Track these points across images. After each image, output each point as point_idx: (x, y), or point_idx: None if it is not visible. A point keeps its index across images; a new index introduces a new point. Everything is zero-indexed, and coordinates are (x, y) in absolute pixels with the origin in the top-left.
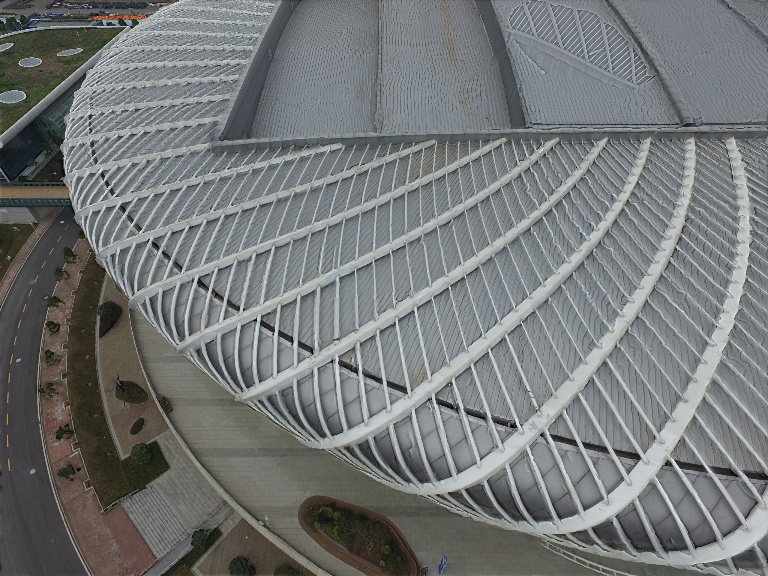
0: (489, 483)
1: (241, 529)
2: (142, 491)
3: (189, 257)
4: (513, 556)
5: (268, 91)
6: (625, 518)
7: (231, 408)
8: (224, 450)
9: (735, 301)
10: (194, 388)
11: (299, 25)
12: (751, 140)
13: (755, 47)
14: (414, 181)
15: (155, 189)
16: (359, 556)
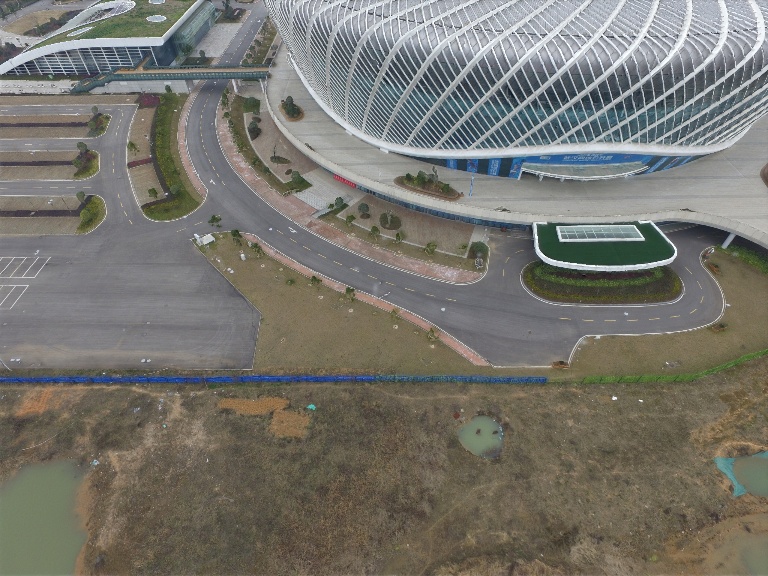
0: (494, 49)
1: (359, 204)
2: (300, 192)
3: (361, 5)
4: (507, 191)
5: None
6: (542, 53)
7: (347, 150)
8: (348, 163)
9: None
10: (324, 144)
11: None
12: None
13: None
14: None
15: None
16: (428, 190)
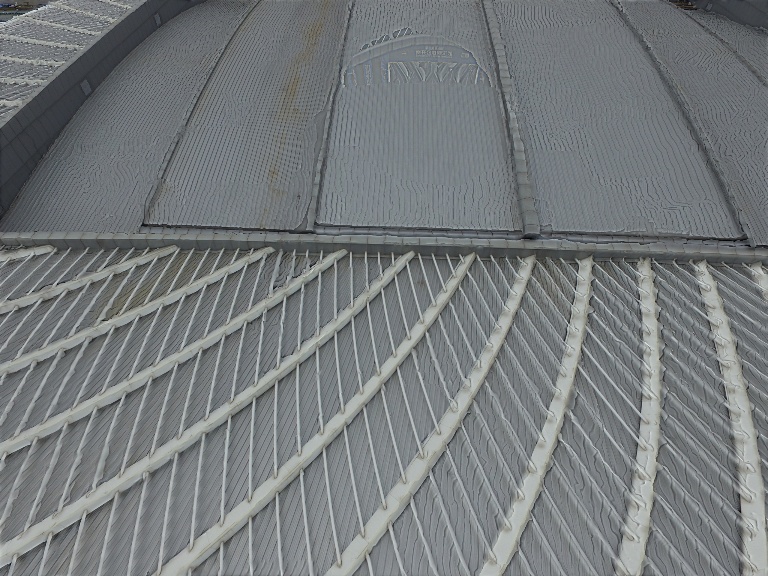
0: None
1: None
2: None
3: None
4: None
5: (65, 138)
6: None
7: None
8: None
9: None
10: None
11: (155, 45)
12: (618, 261)
13: (665, 108)
14: (112, 317)
15: None
16: None
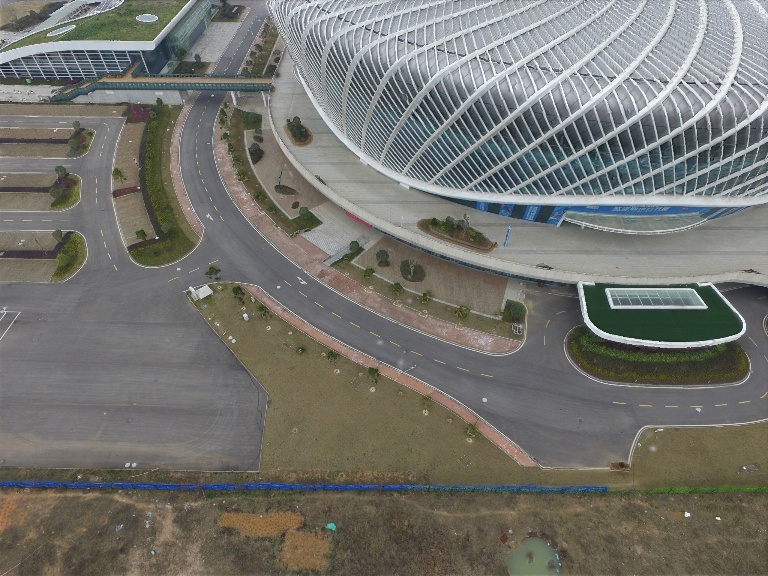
0: (551, 92)
1: (376, 248)
2: (309, 231)
3: None
4: (546, 240)
5: None
6: (609, 100)
7: (363, 184)
8: (364, 201)
9: (662, 32)
10: (336, 176)
11: None
12: None
13: None
14: None
15: (358, 6)
16: (457, 239)
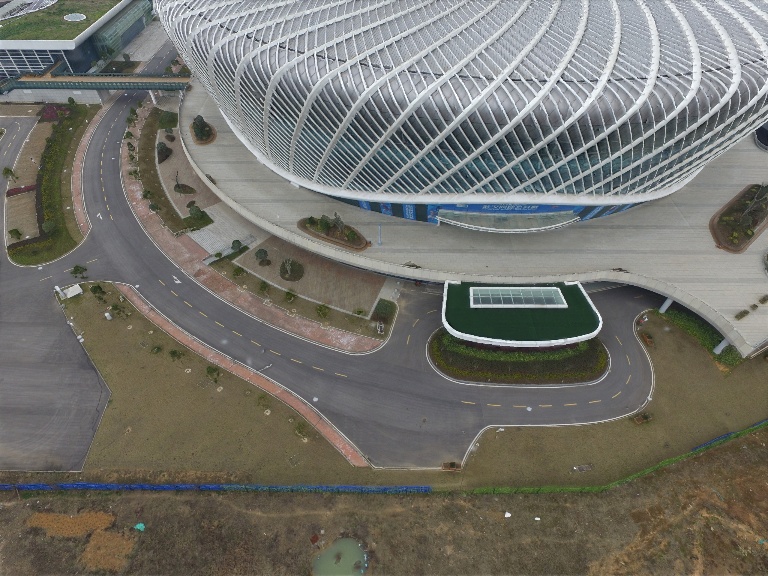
0: (380, 90)
1: (261, 247)
2: (198, 230)
3: (241, 27)
4: (423, 239)
5: None
6: (435, 98)
7: (254, 183)
8: (250, 200)
9: (502, 29)
10: (229, 174)
11: None
12: None
13: None
14: None
15: (219, 4)
16: (332, 238)
